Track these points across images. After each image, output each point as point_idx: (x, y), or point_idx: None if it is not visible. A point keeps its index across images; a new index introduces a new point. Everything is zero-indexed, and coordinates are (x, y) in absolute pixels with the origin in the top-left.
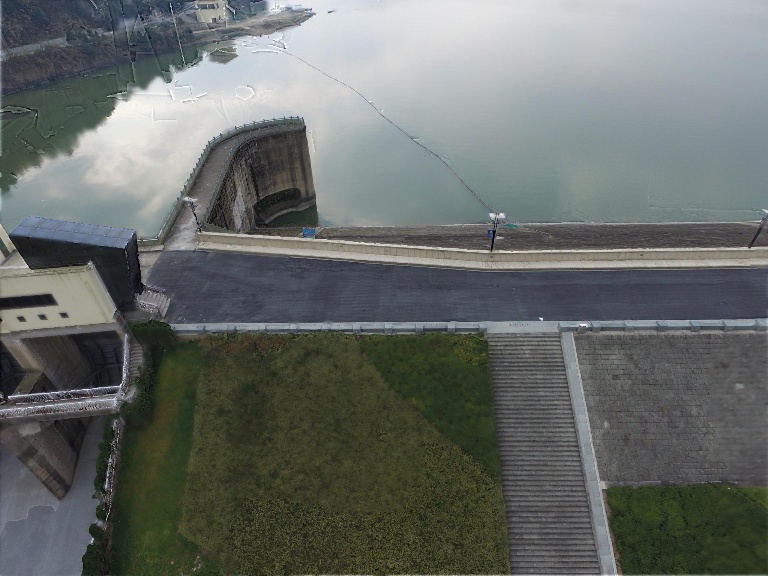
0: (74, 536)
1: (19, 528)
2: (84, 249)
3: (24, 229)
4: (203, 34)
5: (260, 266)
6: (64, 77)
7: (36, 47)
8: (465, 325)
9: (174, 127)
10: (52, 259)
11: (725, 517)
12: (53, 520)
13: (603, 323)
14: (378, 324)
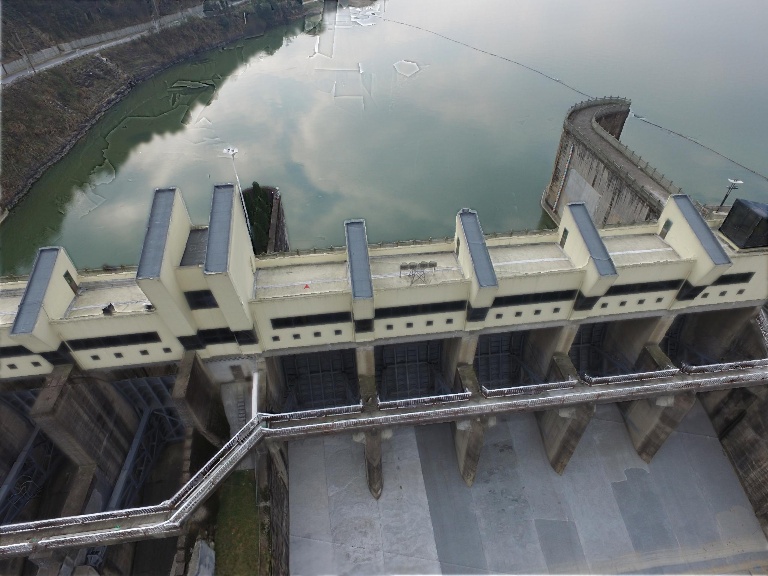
0: (681, 495)
1: (626, 488)
2: None
3: (759, 211)
4: (309, 5)
5: None
6: (205, 50)
7: (173, 18)
8: None
9: (354, 103)
10: (765, 239)
11: None
12: (652, 481)
13: None
14: None
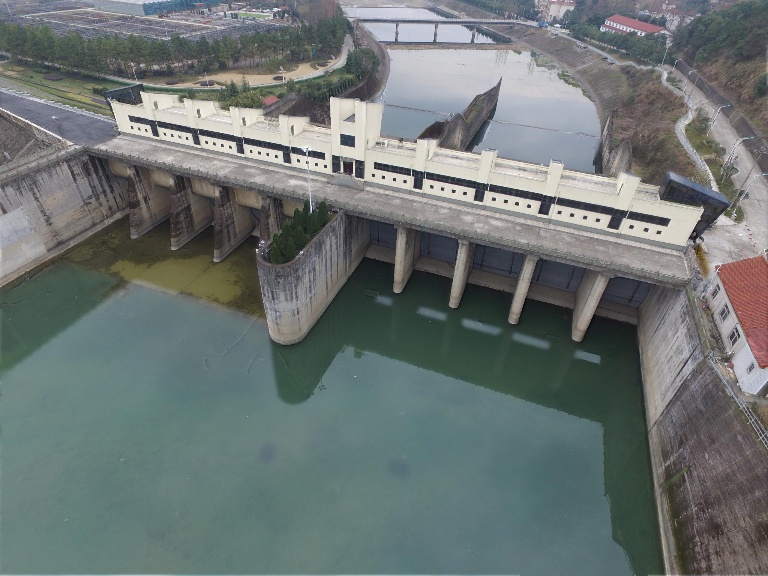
0: None
1: None
2: None
3: None
4: None
5: (65, 131)
6: None
7: None
8: (48, 102)
9: None
10: None
11: None
12: None
13: (16, 94)
14: (68, 109)
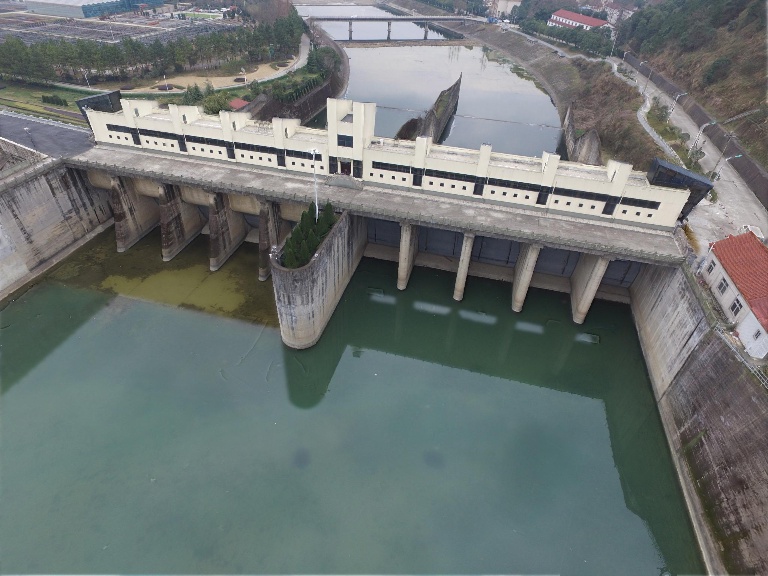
0: None
1: None
2: None
3: None
4: None
5: (35, 143)
6: None
7: None
8: (8, 113)
9: None
10: None
11: None
12: None
13: None
14: None
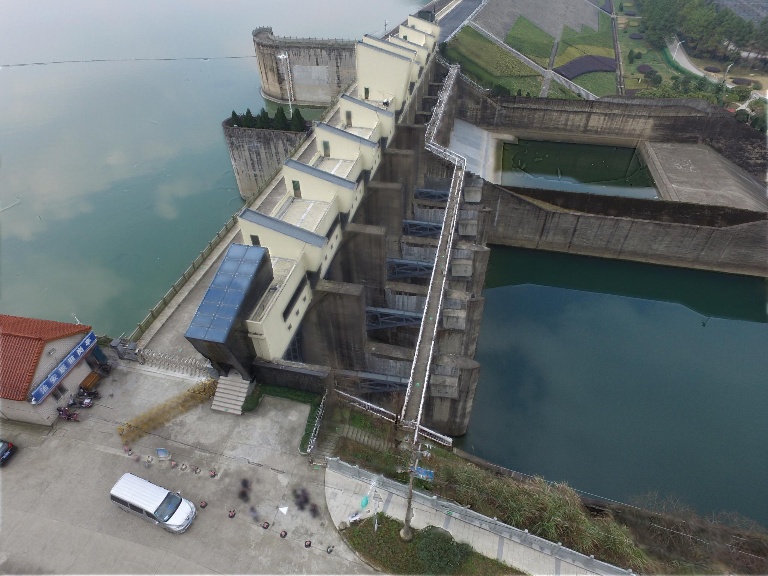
0: (466, 133)
1: None
2: None
3: None
4: None
5: None
6: None
7: None
8: None
9: None
10: None
11: (512, 38)
12: (459, 134)
13: None
14: None
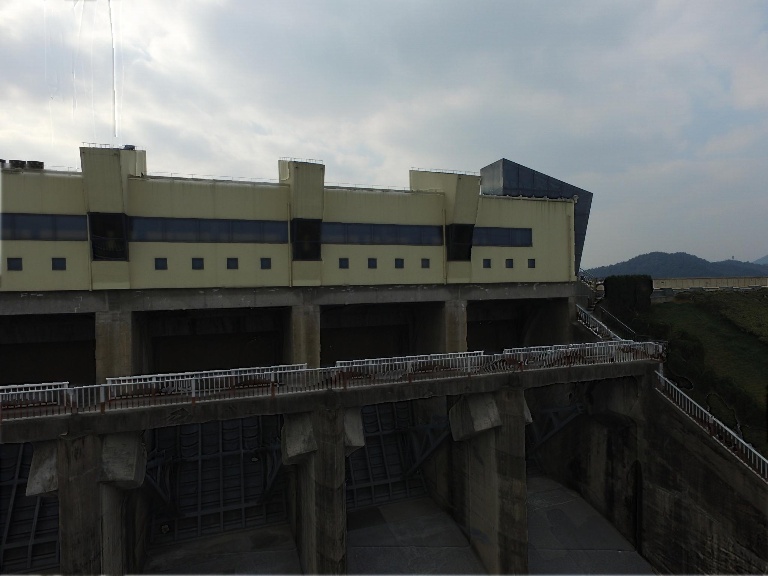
0: None
1: None
2: (557, 189)
3: None
4: None
5: None
6: None
7: None
8: None
9: None
10: None
11: None
12: None
13: None
14: None
